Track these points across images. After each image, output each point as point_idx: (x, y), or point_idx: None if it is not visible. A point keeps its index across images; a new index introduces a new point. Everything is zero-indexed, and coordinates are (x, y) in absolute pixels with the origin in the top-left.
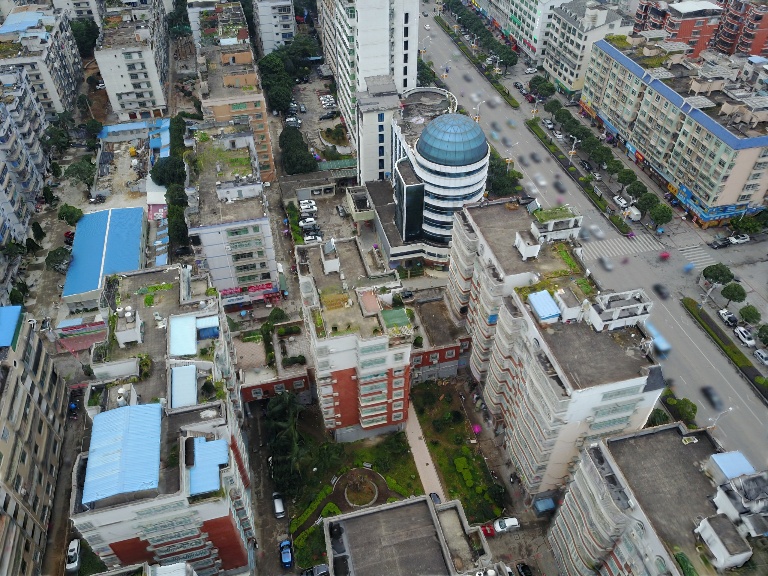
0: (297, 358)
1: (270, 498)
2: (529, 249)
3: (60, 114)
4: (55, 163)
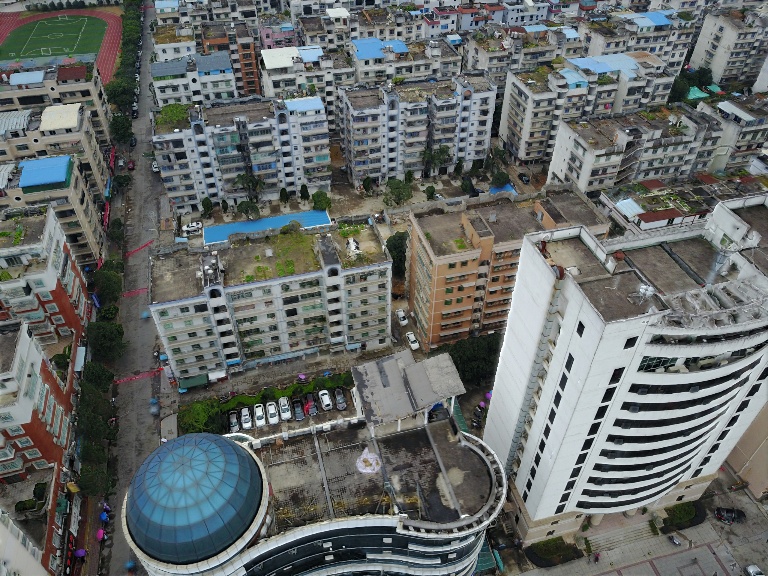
0: None
1: None
2: None
3: (496, 149)
4: (411, 172)
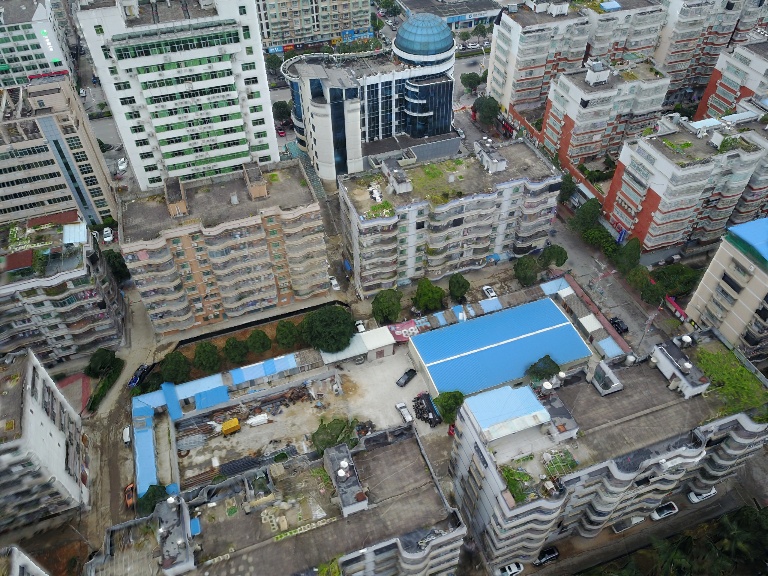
0: (610, 160)
1: None
2: (568, 5)
3: None
4: None
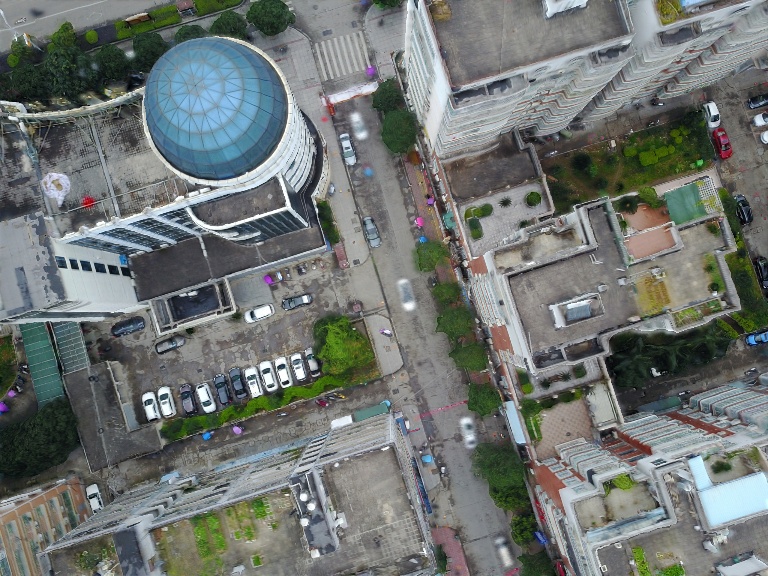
0: None
1: (702, 366)
2: None
3: None
4: None
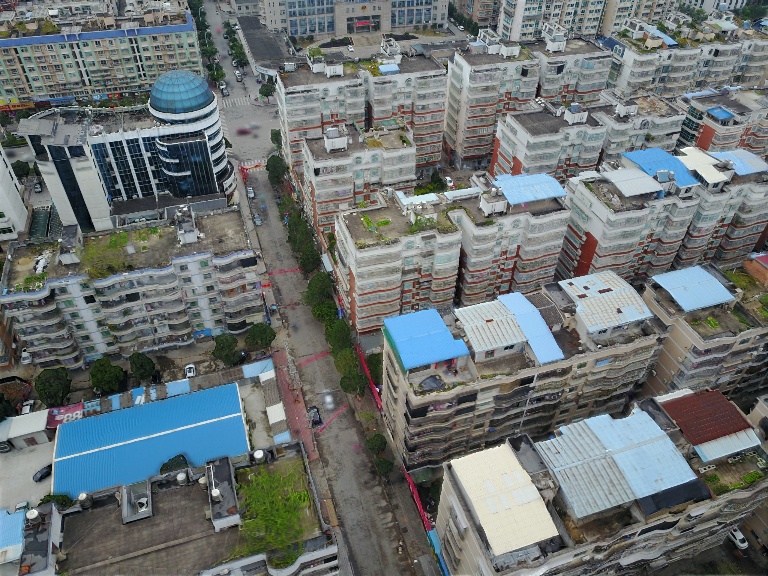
0: None
1: None
2: None
3: None
4: None
